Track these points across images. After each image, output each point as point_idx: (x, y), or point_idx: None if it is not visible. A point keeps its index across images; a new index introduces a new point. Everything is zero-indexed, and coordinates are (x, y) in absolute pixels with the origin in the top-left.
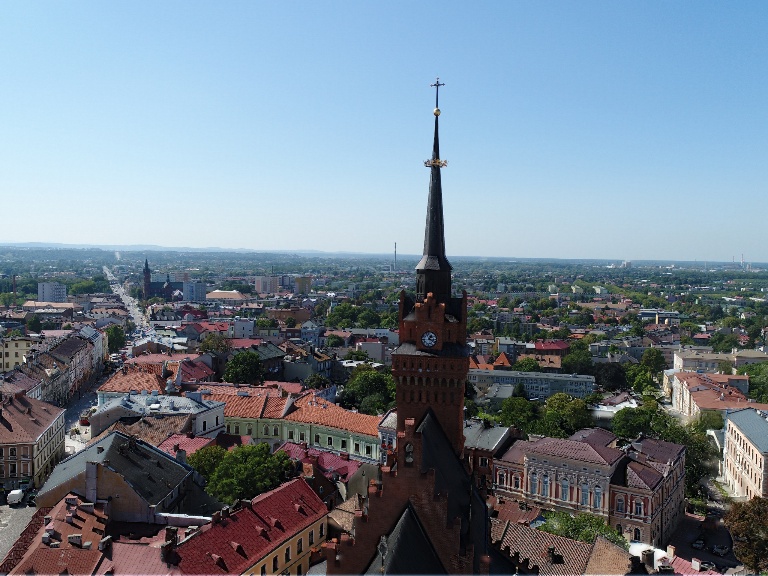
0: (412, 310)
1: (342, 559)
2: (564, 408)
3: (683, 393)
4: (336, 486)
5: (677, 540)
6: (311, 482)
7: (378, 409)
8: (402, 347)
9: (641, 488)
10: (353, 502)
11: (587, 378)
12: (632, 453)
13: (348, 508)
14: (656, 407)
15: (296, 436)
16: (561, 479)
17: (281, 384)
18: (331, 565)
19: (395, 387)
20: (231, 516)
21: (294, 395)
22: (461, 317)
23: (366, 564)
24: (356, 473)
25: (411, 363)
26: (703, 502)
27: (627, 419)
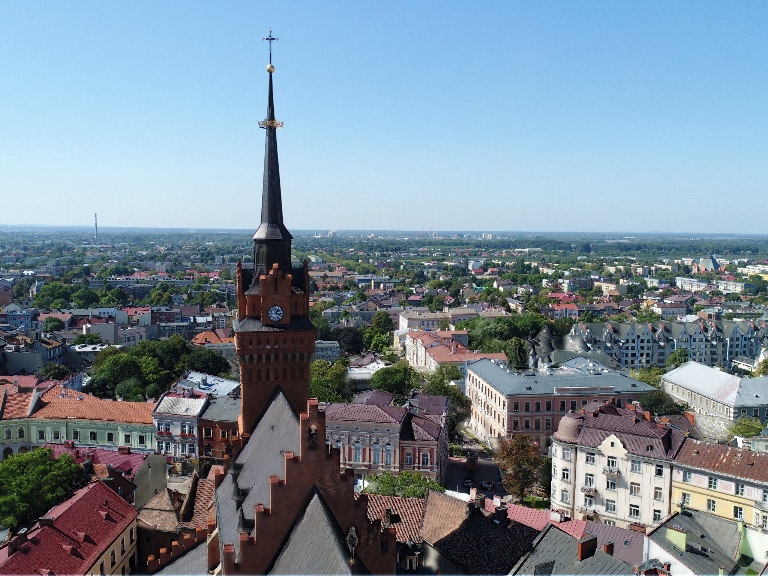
0: (254, 283)
1: (242, 561)
2: (324, 374)
3: (417, 350)
4: (134, 484)
5: (451, 482)
6: (109, 484)
7: (136, 395)
8: (246, 324)
9: (427, 440)
10: (163, 498)
11: (331, 344)
12: (413, 409)
13: (158, 506)
14: (407, 365)
15: (48, 435)
16: (354, 442)
17: (9, 378)
18: (230, 570)
19: (151, 369)
20: (31, 539)
21: (28, 389)
22: (305, 288)
23: (270, 561)
24: (141, 467)
25: (258, 340)
26: (461, 445)
27: (385, 378)
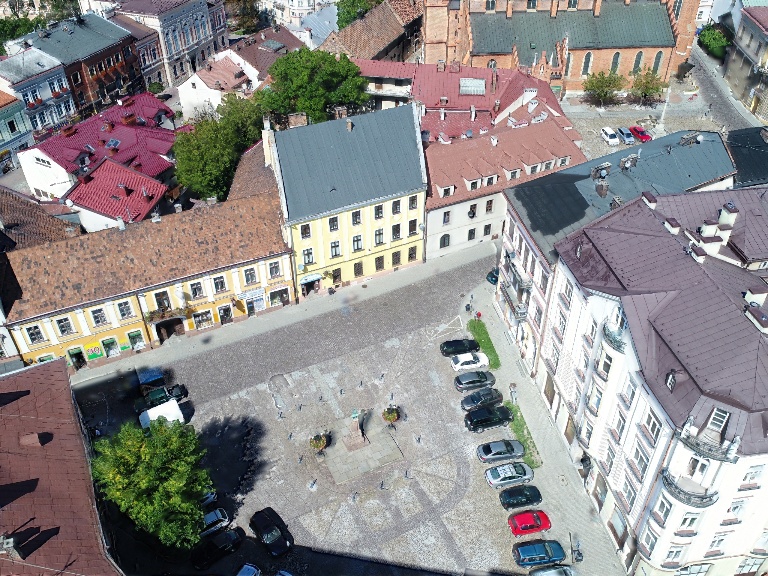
0: None
1: None
2: None
3: None
4: None
5: None
6: None
7: None
8: None
9: (219, 1)
10: None
11: None
12: None
13: None
14: None
15: None
16: None
17: None
18: None
19: None
20: None
21: None
22: None
23: None
24: None
25: None
26: None
27: None
